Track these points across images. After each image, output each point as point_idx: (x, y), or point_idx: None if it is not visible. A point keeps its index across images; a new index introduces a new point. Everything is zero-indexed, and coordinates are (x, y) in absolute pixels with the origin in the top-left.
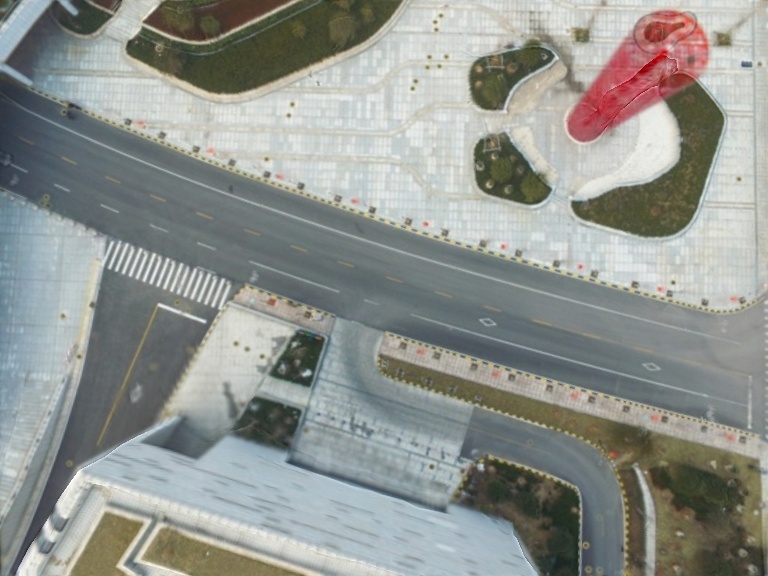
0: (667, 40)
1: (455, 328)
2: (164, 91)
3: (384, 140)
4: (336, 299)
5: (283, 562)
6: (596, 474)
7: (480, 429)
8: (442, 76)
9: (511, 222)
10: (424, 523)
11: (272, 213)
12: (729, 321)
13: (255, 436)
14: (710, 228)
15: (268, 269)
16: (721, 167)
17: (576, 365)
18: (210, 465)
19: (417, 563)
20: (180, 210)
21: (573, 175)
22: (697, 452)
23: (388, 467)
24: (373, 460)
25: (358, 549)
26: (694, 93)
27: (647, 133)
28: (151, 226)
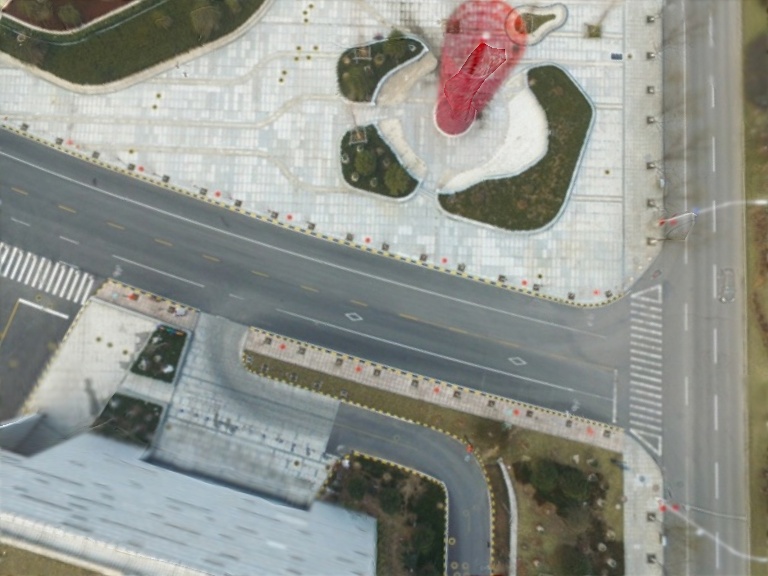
0: (537, 32)
1: (321, 323)
2: (27, 82)
3: (251, 132)
4: (201, 294)
5: (83, 561)
6: (463, 469)
7: (346, 425)
8: (311, 67)
9: (378, 215)
10: (267, 520)
11: (136, 206)
12: (595, 315)
13: (106, 433)
14: (577, 221)
15: (132, 263)
16: (589, 160)
17: (442, 360)
18: (41, 463)
19: (228, 561)
20: (42, 203)
21: (442, 168)
22: (560, 446)
23: (252, 464)
24: (237, 457)
25: (165, 547)
26: (562, 85)
27: (517, 126)
28: (12, 220)
